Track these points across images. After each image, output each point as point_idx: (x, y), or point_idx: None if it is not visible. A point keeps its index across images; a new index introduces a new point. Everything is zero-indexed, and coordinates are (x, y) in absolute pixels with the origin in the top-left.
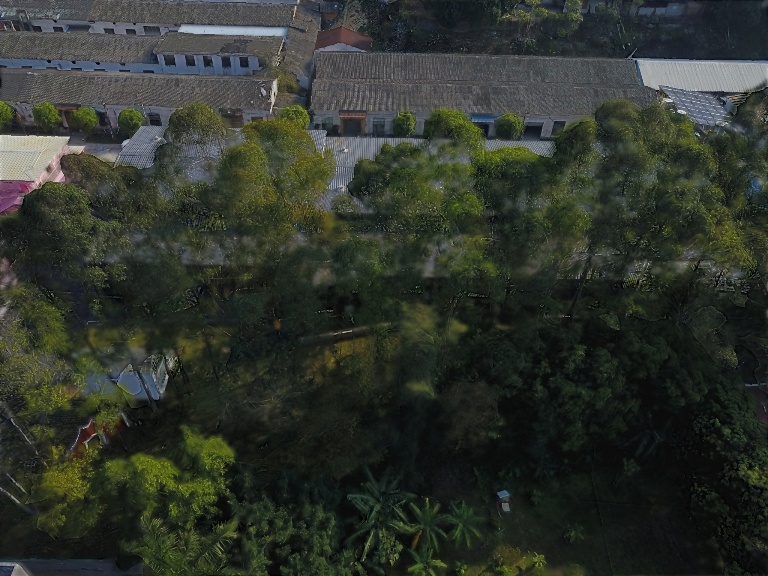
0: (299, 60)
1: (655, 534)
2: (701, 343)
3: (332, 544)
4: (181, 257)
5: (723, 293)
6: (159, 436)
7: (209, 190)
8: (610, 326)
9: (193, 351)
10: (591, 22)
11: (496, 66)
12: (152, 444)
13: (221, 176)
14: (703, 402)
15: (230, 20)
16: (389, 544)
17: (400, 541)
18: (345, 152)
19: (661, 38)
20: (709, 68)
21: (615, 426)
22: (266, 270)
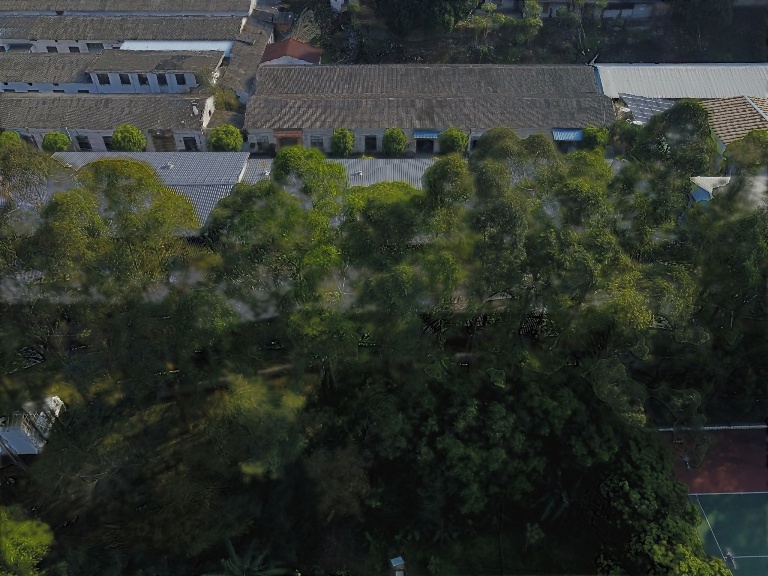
0: (240, 75)
1: None
2: (601, 399)
3: None
4: (2, 316)
5: (653, 330)
6: (31, 496)
7: (24, 243)
8: None
9: None
10: (552, 27)
11: (445, 77)
12: (22, 505)
13: None
14: (614, 461)
15: (175, 35)
16: None
17: None
18: (266, 176)
19: (628, 41)
20: (674, 73)
21: (518, 487)
22: (109, 325)
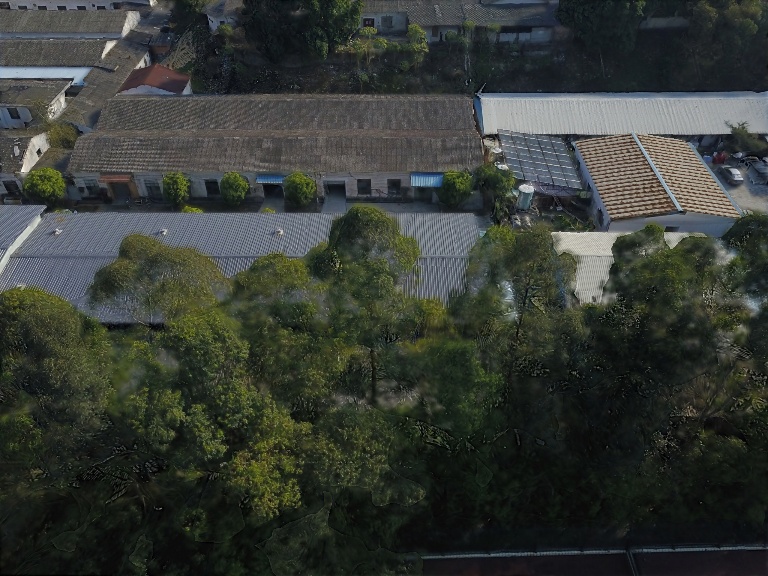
0: (87, 107)
1: None
2: None
3: None
4: None
5: (431, 445)
6: None
7: None
8: (132, 562)
9: None
10: (441, 52)
11: (309, 110)
12: None
13: None
14: None
15: (30, 60)
16: None
17: None
18: (56, 235)
19: (525, 68)
20: (564, 106)
21: None
22: None
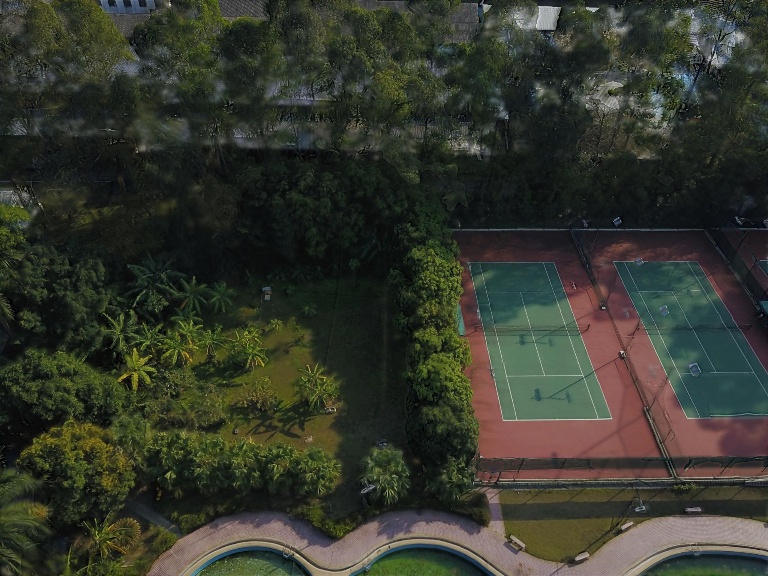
0: None
1: (372, 313)
2: (387, 161)
3: (109, 291)
4: (2, 88)
5: (457, 153)
6: None
7: (17, 37)
8: None
9: (56, 202)
10: None
11: None
12: None
13: (27, 29)
14: (405, 214)
15: None
16: (156, 299)
17: (167, 300)
18: None
19: None
20: (544, 11)
21: (346, 235)
22: None
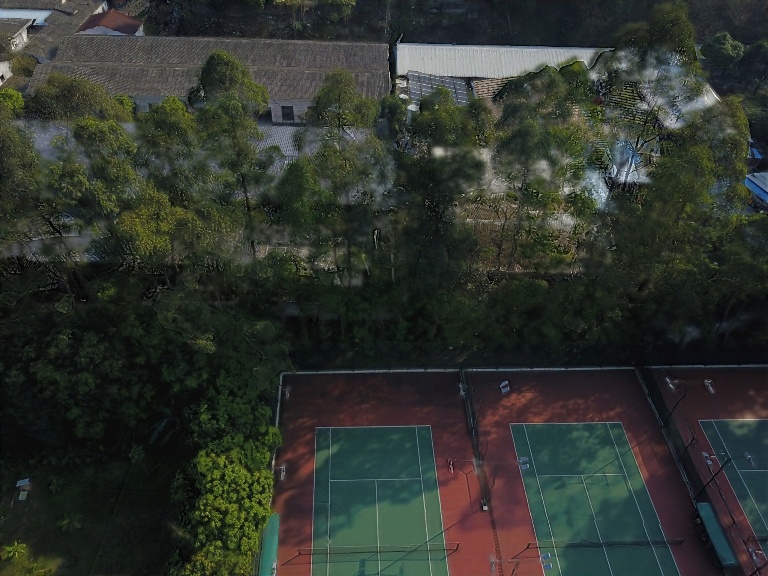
0: (47, 43)
1: (163, 523)
2: None
3: None
4: None
5: (303, 278)
6: None
7: None
8: None
9: None
10: (368, 6)
11: (244, 50)
12: None
13: None
14: (205, 388)
15: None
16: None
17: None
18: None
19: (442, 23)
20: (469, 53)
21: (127, 413)
22: None
